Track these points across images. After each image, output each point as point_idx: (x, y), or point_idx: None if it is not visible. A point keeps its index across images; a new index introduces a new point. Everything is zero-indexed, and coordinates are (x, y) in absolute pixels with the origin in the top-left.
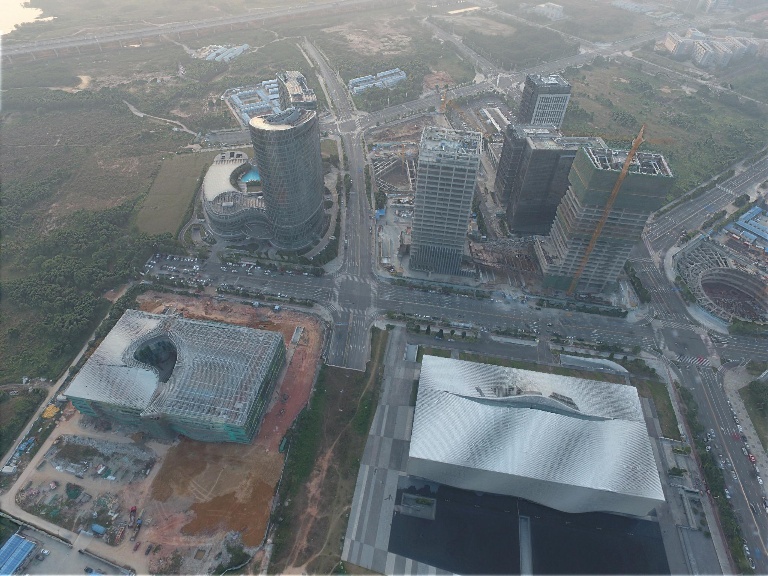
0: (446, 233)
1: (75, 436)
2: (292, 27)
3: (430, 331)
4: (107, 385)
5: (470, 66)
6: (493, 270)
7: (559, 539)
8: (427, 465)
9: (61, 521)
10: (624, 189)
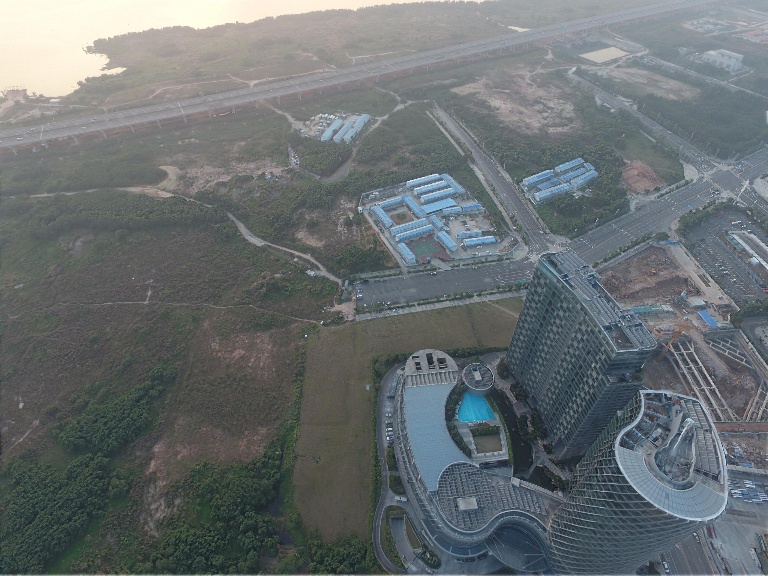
0: None
1: None
2: (416, 87)
3: None
4: None
5: (671, 152)
6: None
7: None
8: None
9: None
10: None
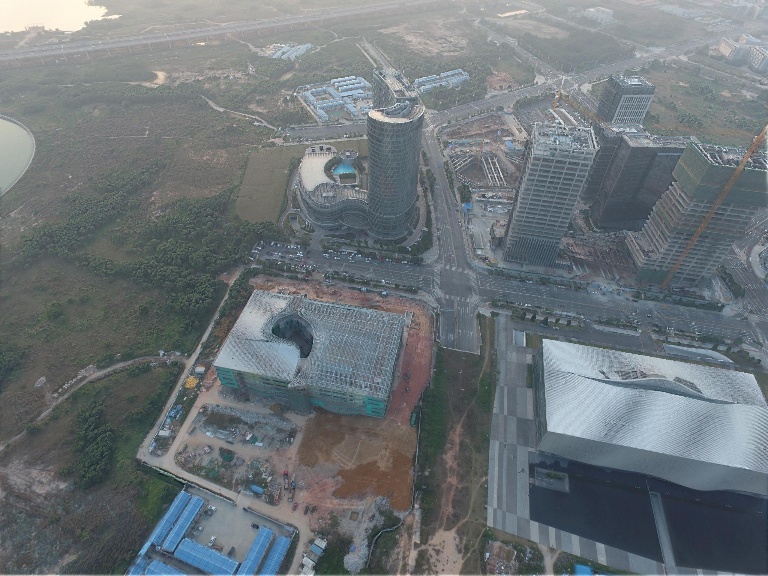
0: (547, 225)
1: (218, 405)
2: (350, 28)
3: (535, 319)
4: (252, 358)
5: (530, 68)
6: (586, 263)
7: (689, 515)
8: (563, 440)
9: (221, 481)
10: (737, 185)
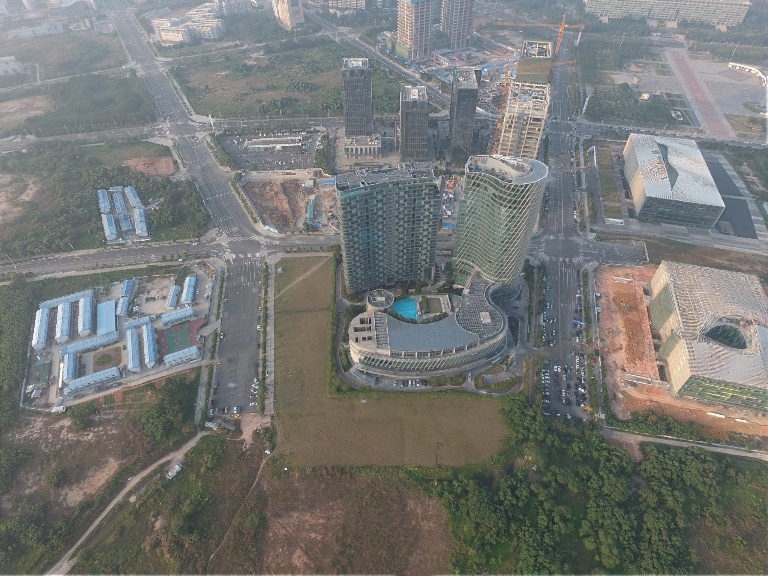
0: None
1: None
2: None
3: None
4: None
5: None
6: None
7: None
8: None
9: None
10: None
